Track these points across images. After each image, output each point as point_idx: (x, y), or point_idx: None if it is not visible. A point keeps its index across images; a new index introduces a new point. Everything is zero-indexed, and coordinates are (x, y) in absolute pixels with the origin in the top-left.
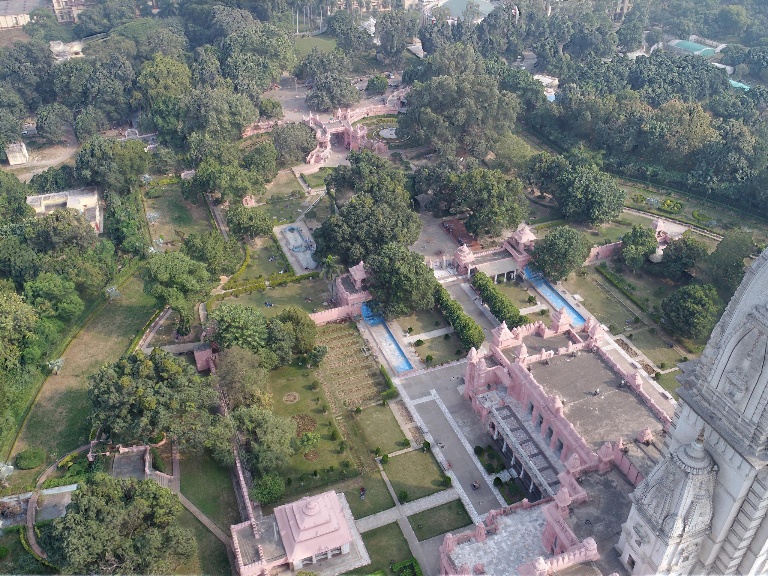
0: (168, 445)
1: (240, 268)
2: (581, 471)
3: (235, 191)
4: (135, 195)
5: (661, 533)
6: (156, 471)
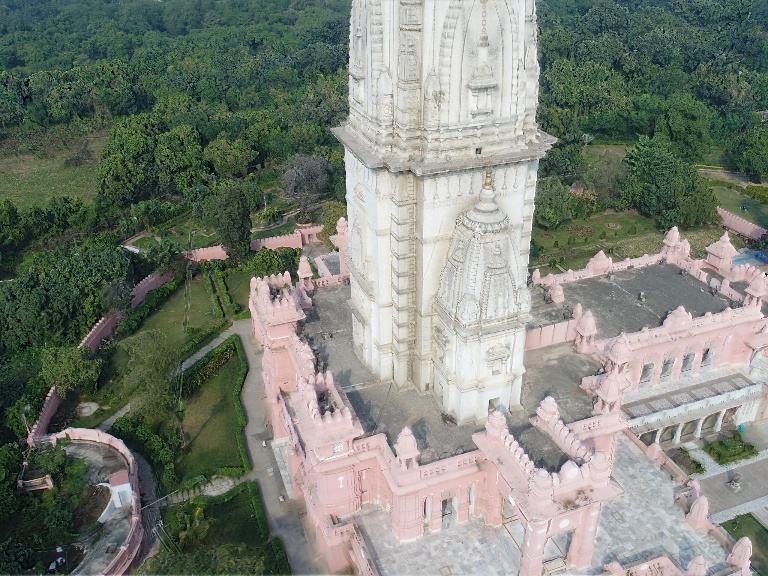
0: None
1: None
2: None
3: None
4: None
5: None
6: None
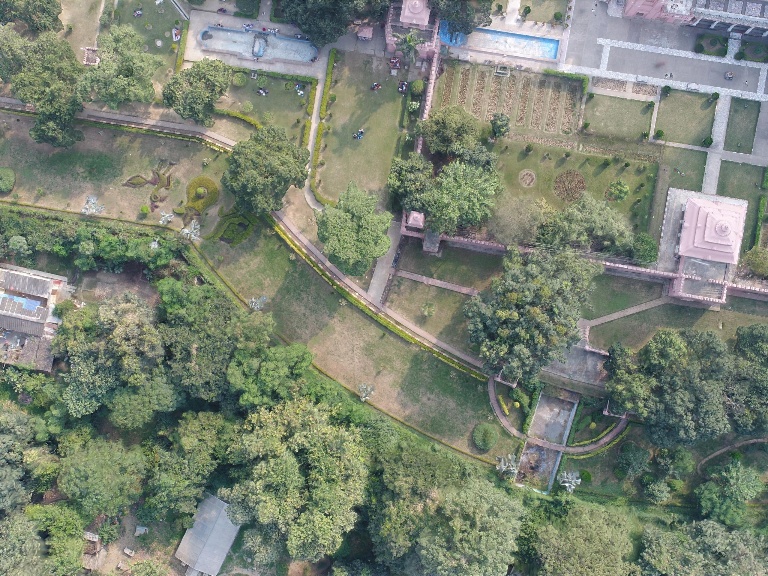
0: None
1: None
2: None
3: (141, 80)
4: (6, 211)
5: None
6: None
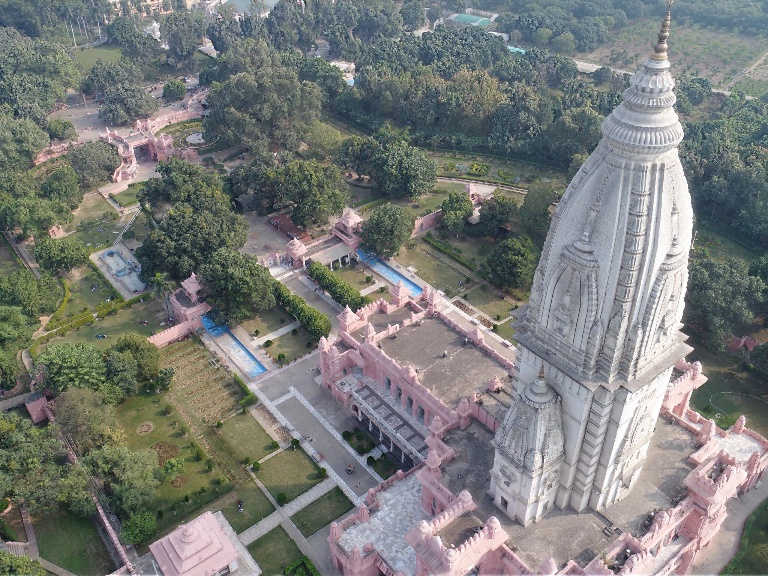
0: (15, 510)
1: (61, 305)
2: (445, 431)
3: (38, 224)
4: None
5: (525, 469)
6: (7, 542)
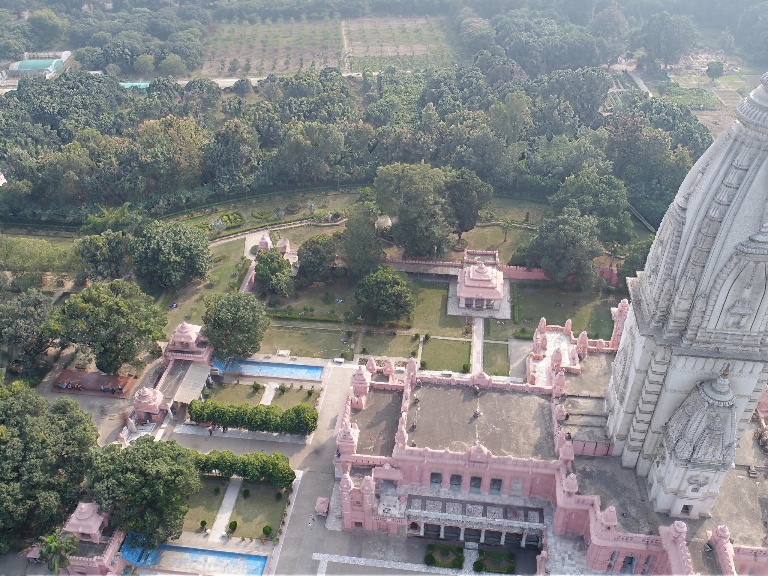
0: None
1: None
2: None
3: None
4: None
5: (724, 466)
6: None
